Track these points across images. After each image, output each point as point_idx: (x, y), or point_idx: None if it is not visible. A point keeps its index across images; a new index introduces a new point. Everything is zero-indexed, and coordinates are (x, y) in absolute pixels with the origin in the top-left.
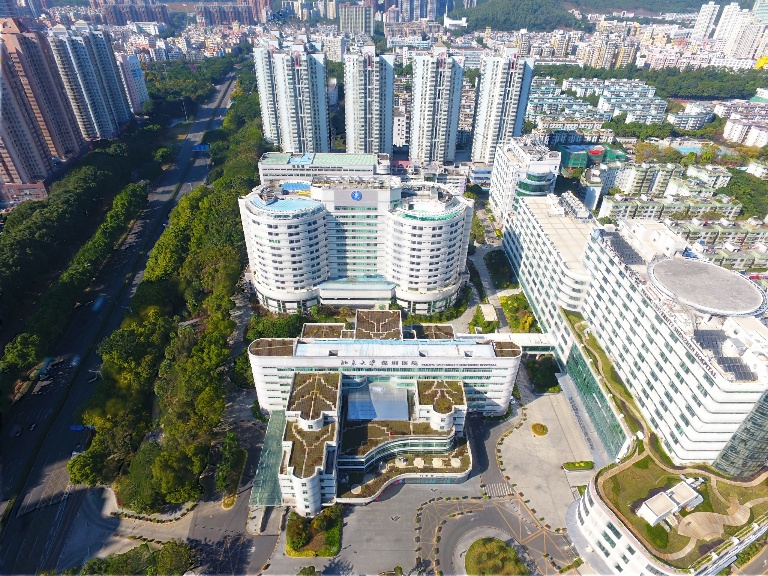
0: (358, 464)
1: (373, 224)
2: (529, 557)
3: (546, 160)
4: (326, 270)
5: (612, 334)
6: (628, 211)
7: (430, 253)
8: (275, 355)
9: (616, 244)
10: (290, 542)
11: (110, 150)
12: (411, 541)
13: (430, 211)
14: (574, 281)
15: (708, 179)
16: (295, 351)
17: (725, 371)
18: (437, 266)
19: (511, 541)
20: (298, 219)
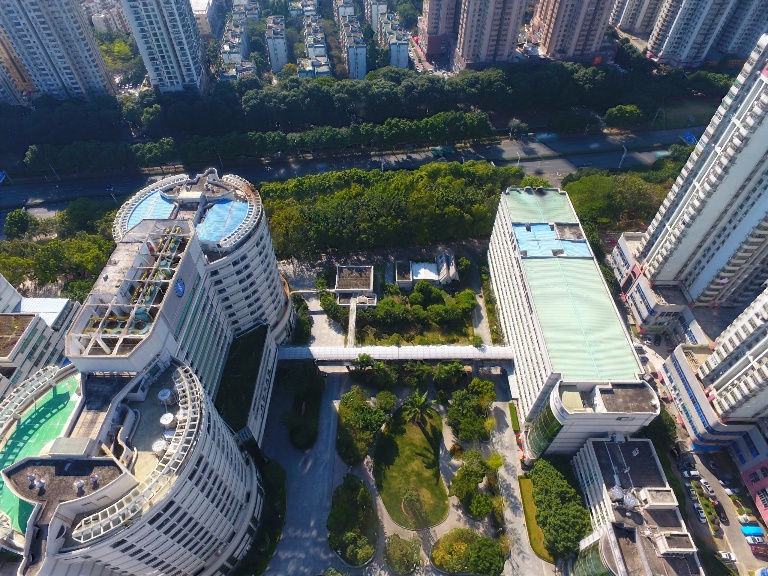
0: None
1: None
2: None
3: None
4: None
5: None
6: None
7: None
8: None
9: None
10: None
11: (581, 71)
12: None
13: None
14: None
15: None
16: None
17: None
18: None
19: None
20: None
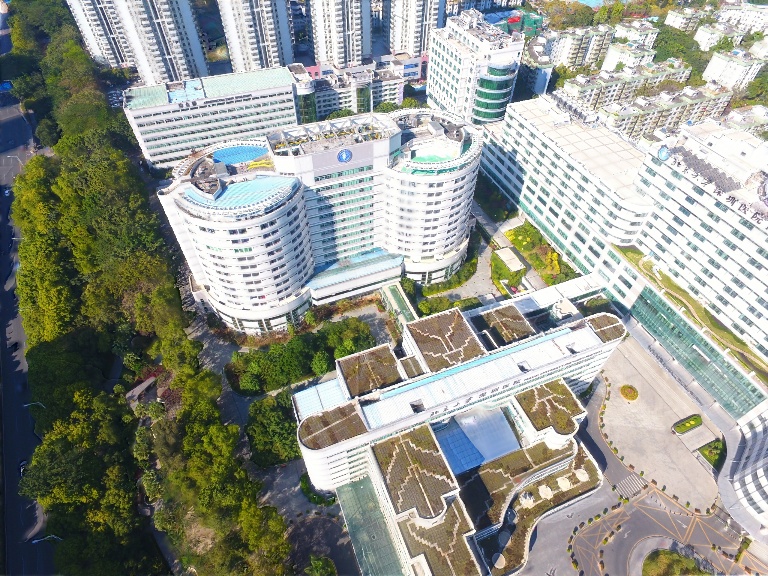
0: (492, 532)
1: (367, 188)
2: (700, 557)
3: (509, 46)
4: (311, 262)
5: (702, 274)
6: (593, 94)
7: (450, 212)
8: (343, 438)
9: (693, 164)
10: None
11: None
12: None
13: (438, 155)
14: (634, 214)
15: (638, 39)
16: (366, 422)
17: None
18: (456, 224)
19: (675, 545)
20: (274, 212)
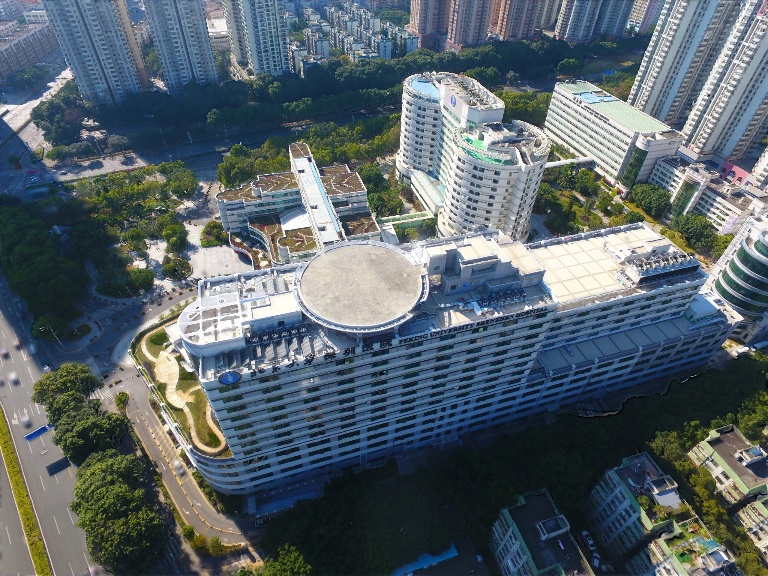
0: None
1: None
2: None
3: None
4: (428, 162)
5: None
6: None
7: (454, 185)
8: (293, 153)
9: None
10: (205, 226)
11: (534, 44)
12: (212, 274)
13: None
14: None
15: None
16: (299, 158)
17: (221, 286)
18: (457, 204)
19: None
20: (412, 98)
